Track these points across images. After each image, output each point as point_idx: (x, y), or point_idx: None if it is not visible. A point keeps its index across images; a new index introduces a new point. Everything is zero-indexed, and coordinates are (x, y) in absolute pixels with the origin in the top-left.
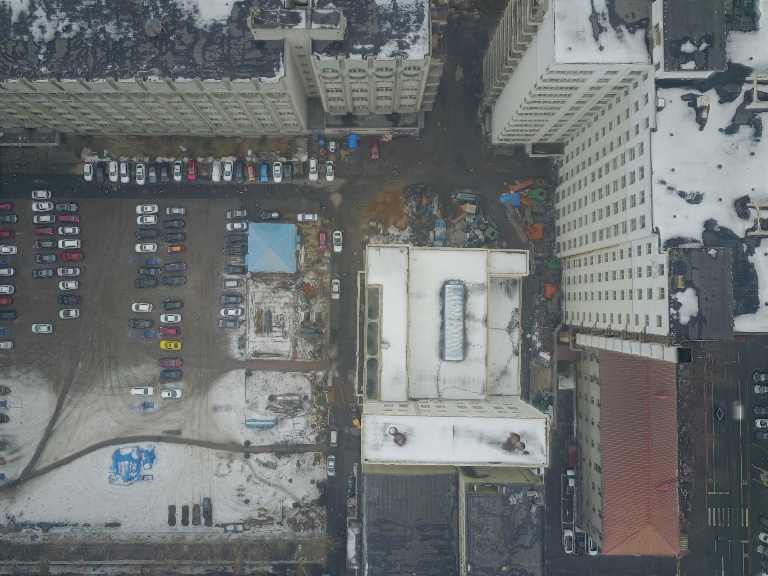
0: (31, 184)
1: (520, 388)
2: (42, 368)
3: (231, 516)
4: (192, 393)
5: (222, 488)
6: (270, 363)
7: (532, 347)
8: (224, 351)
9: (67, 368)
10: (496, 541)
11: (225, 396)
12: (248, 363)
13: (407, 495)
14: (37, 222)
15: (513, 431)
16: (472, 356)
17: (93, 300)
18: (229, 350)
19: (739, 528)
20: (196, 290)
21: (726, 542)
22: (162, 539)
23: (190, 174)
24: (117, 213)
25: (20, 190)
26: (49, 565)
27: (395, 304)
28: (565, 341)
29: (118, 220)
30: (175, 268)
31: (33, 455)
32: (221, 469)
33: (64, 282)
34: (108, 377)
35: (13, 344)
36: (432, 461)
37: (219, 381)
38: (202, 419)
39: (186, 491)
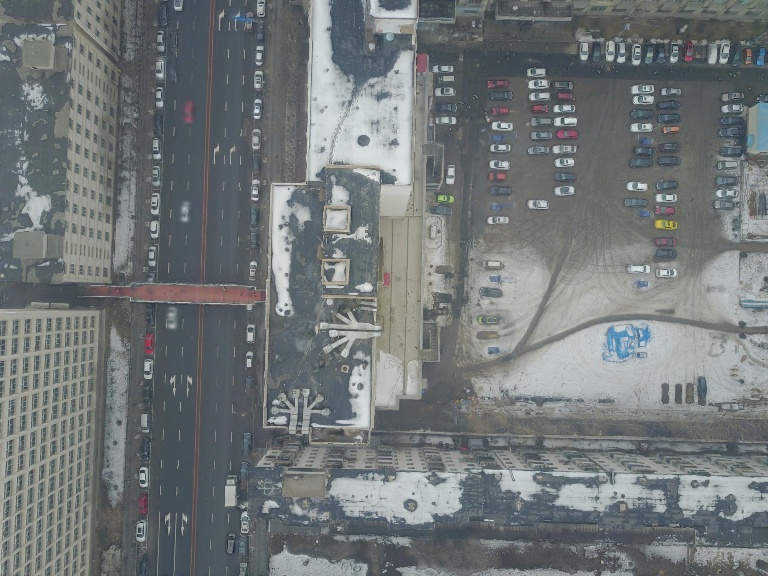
0: (525, 62)
1: None
2: (535, 244)
3: (724, 396)
4: (685, 273)
5: (715, 368)
6: (764, 245)
7: None
8: (718, 232)
9: (561, 245)
10: None
11: (719, 277)
12: (742, 245)
13: None
14: (535, 99)
15: None
16: None
17: (587, 178)
18: (723, 231)
19: None
20: (690, 171)
21: None
22: (656, 416)
23: (687, 55)
24: (610, 93)
25: (513, 68)
26: (544, 439)
27: None
28: None
29: (612, 100)
30: (673, 148)
31: (527, 330)
32: (714, 349)
33: (563, 159)
34: (602, 255)
35: (509, 219)
36: None
37: (713, 262)
38: (695, 299)
39: (679, 370)
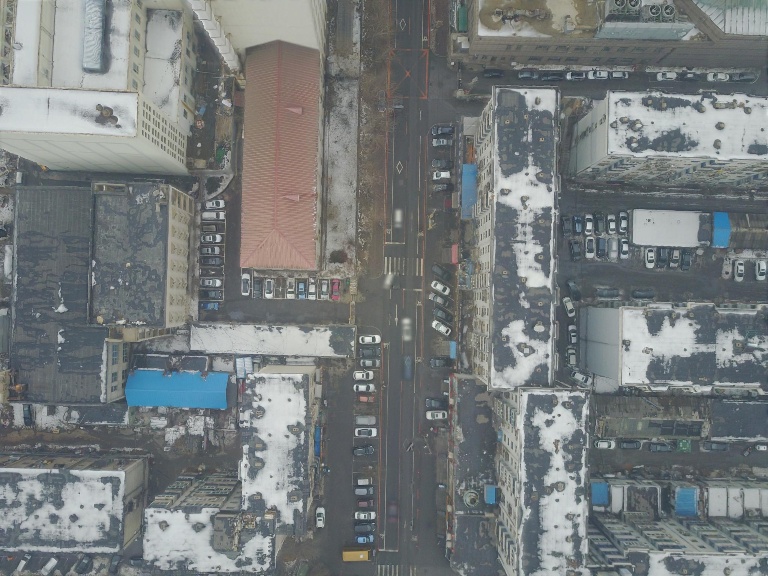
0: None
1: (179, 115)
2: None
3: None
4: None
5: None
6: None
7: (218, 97)
8: None
9: None
10: (121, 238)
11: None
12: None
13: (56, 208)
14: None
15: (106, 105)
16: (115, 69)
17: None
18: None
19: (414, 277)
20: None
21: (401, 291)
22: None
23: None
24: None
25: None
26: None
27: (31, 8)
28: (244, 87)
29: None
30: None
31: None
32: None
33: None
34: None
35: None
36: (26, 131)
37: None
38: None
39: None
